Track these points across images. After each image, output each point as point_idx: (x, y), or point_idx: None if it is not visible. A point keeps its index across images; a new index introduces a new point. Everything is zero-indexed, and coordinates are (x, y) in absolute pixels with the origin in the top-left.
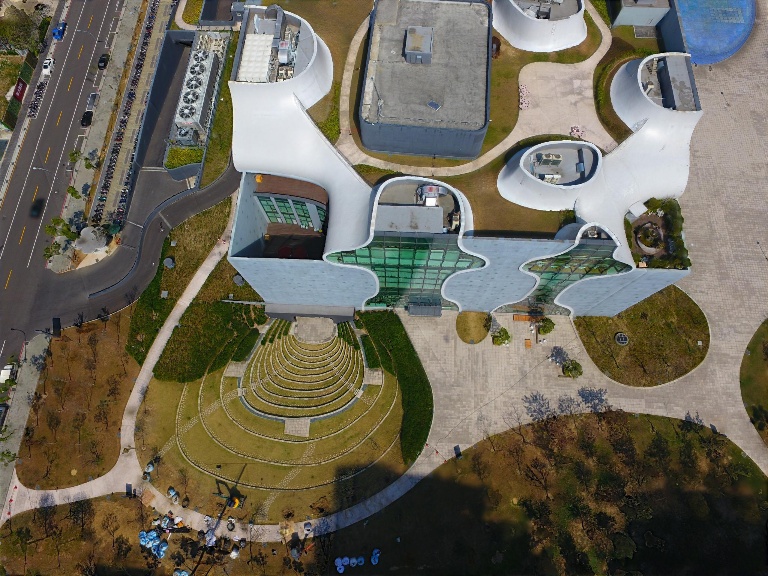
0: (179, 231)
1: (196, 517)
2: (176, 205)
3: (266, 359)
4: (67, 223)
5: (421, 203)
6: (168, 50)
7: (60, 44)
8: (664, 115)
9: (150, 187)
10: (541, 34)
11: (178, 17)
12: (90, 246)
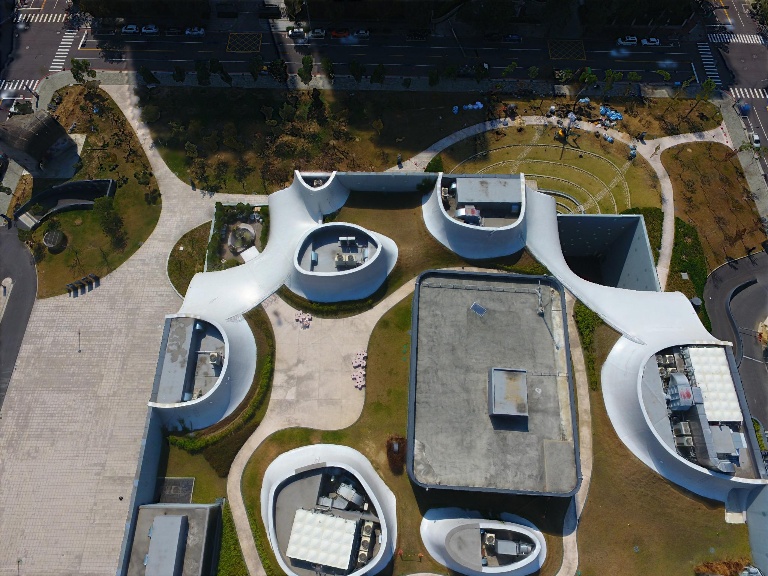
0: None
1: (586, 128)
2: None
3: None
4: None
5: None
6: None
7: None
8: None
9: (762, 408)
10: None
11: None
12: None
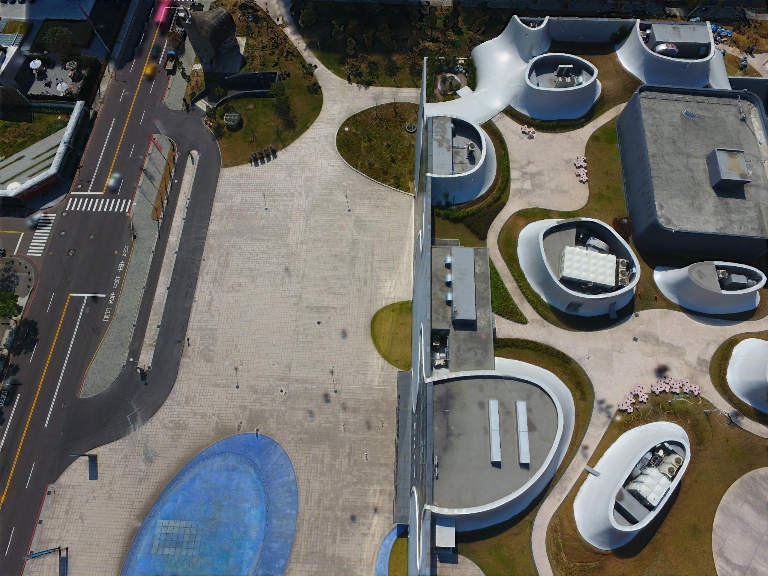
0: None
1: None
2: None
3: None
4: None
5: None
6: None
7: None
8: None
9: None
10: None
11: None
12: None
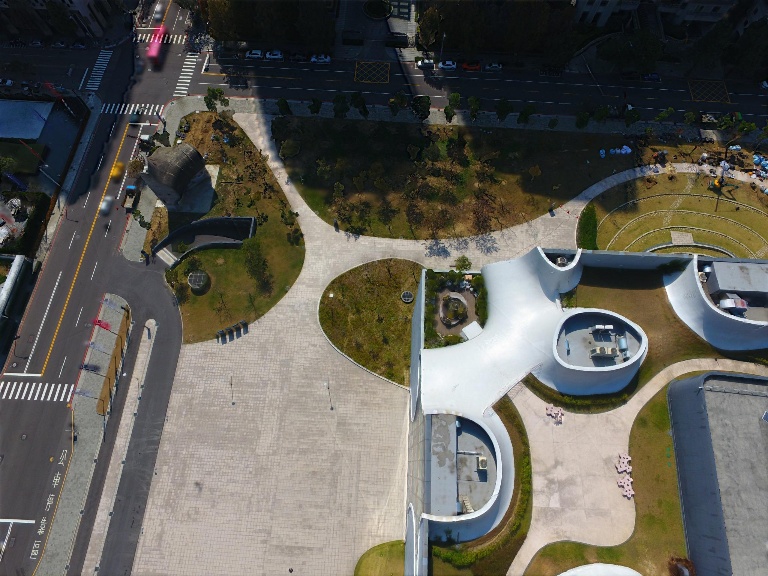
0: None
1: (741, 178)
2: None
3: None
4: None
5: None
6: None
7: None
8: None
9: None
10: None
11: None
12: None
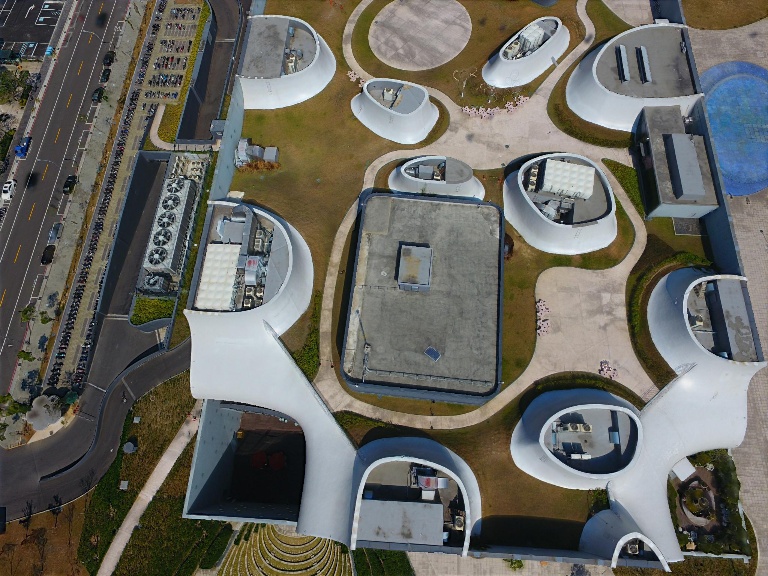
0: (144, 404)
1: None
2: (142, 369)
3: (240, 561)
4: (20, 385)
5: (416, 486)
6: (141, 172)
7: (23, 162)
8: (717, 364)
9: (115, 340)
10: (563, 237)
11: (153, 132)
12: (42, 421)
